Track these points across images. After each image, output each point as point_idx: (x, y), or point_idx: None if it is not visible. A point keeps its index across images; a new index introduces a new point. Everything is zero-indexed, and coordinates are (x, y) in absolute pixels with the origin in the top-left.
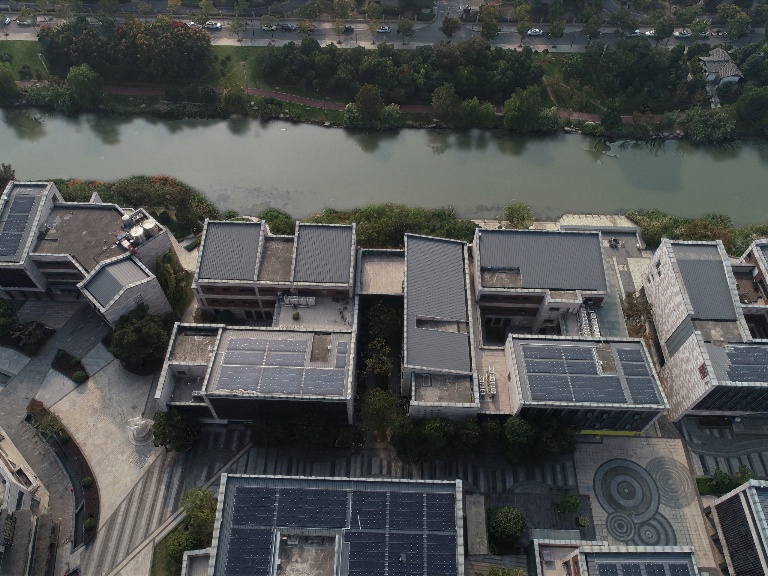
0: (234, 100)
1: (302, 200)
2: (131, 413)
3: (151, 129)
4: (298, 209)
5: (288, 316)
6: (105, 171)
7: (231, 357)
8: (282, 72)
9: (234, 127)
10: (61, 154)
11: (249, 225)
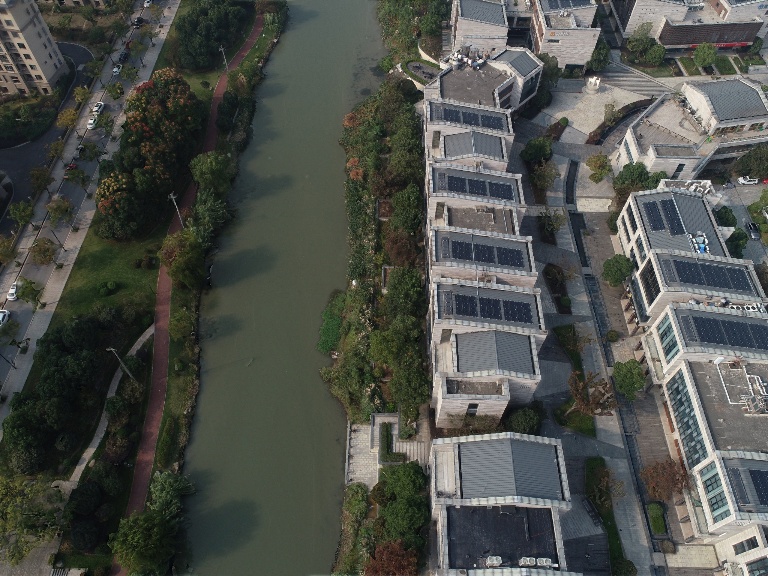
0: (251, 75)
1: (368, 52)
2: (580, 98)
3: (265, 148)
4: (378, 53)
5: (515, 8)
6: (326, 172)
7: (565, 5)
8: (214, 48)
9: (269, 95)
10: (297, 211)
11: (460, 2)
